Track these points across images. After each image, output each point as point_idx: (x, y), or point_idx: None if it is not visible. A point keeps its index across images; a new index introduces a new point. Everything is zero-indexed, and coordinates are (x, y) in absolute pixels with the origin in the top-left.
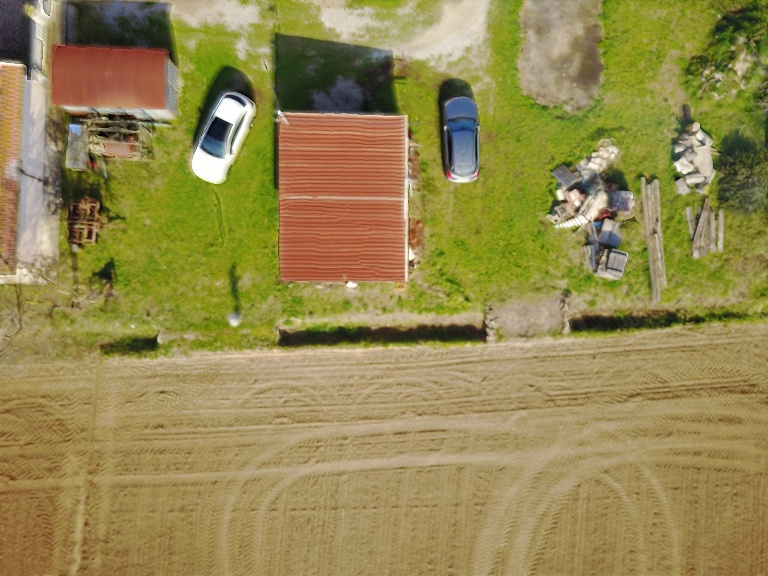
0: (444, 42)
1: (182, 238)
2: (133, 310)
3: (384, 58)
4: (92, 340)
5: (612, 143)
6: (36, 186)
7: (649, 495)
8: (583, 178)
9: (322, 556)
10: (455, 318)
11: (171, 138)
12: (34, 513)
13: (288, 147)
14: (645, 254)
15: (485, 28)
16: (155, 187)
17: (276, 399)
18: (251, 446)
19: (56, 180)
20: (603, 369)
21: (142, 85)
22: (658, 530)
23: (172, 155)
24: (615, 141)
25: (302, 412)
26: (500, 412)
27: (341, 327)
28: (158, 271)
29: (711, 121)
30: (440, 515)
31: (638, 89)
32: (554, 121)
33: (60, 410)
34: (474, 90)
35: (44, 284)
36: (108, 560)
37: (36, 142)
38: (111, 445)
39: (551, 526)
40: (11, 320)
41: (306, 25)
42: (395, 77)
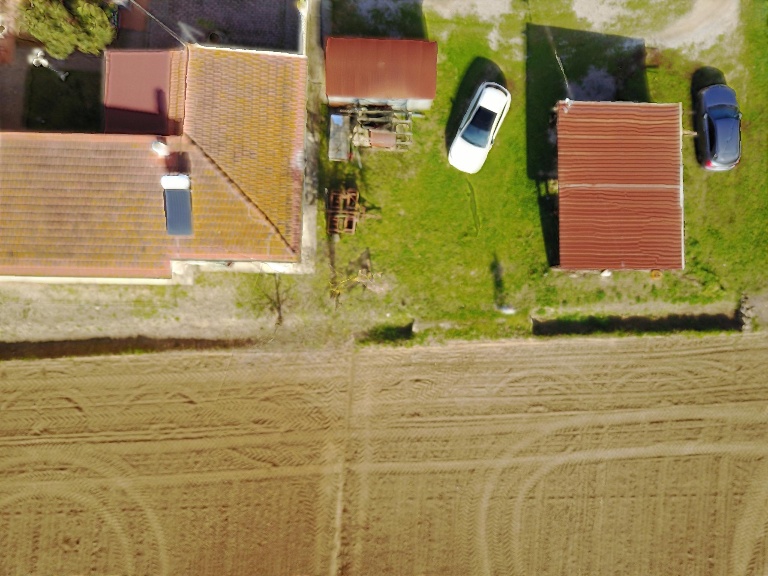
0: (697, 30)
1: (436, 227)
2: (388, 299)
3: (636, 47)
4: (346, 329)
5: None
6: None
7: None
8: None
9: (581, 544)
10: (707, 307)
11: (423, 128)
12: (296, 499)
13: (566, 135)
14: None
15: (738, 15)
16: (409, 177)
17: (531, 387)
18: (507, 434)
19: (313, 170)
20: None
21: (413, 75)
22: None
23: (425, 145)
24: None
25: (557, 400)
26: (757, 401)
27: (591, 316)
28: (412, 260)
29: None
30: (699, 504)
31: None
32: None
33: (317, 398)
34: (727, 78)
35: (303, 273)
36: (369, 546)
37: None
38: (368, 432)
39: None
40: (270, 309)
41: (557, 15)
42: (647, 65)
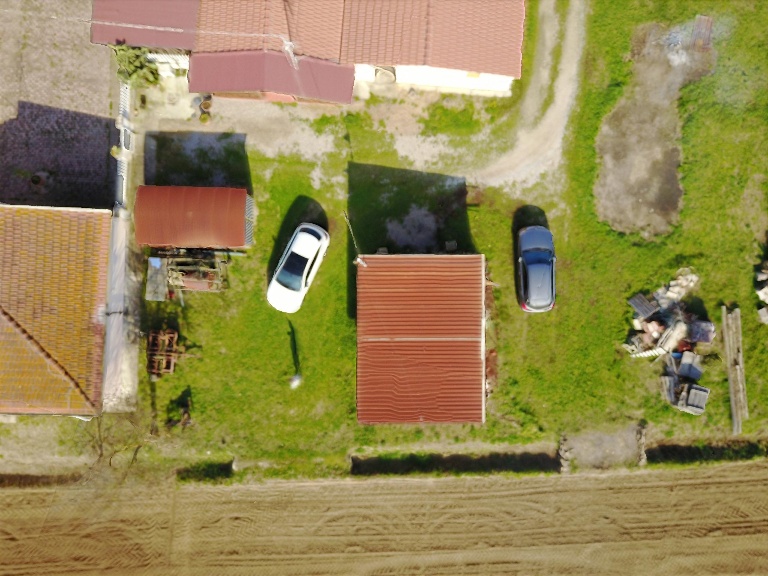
0: (517, 168)
1: (256, 366)
2: (209, 437)
3: (457, 185)
4: (169, 465)
5: (691, 272)
6: (117, 319)
7: None
8: (661, 307)
9: None
10: (528, 446)
11: (245, 266)
12: None
13: (365, 289)
14: (726, 385)
15: (559, 154)
16: (230, 315)
17: (349, 527)
18: (324, 574)
19: (135, 309)
20: (681, 502)
21: (221, 224)
22: None
23: (247, 283)
24: (694, 269)
25: (375, 541)
26: (575, 545)
27: (413, 454)
28: (233, 398)
29: None
30: None
31: (718, 215)
32: (630, 248)
33: (139, 534)
34: (548, 216)
35: (124, 411)
36: None
37: (117, 276)
38: (188, 570)
39: None
40: (92, 446)
41: (378, 153)
42: (468, 204)
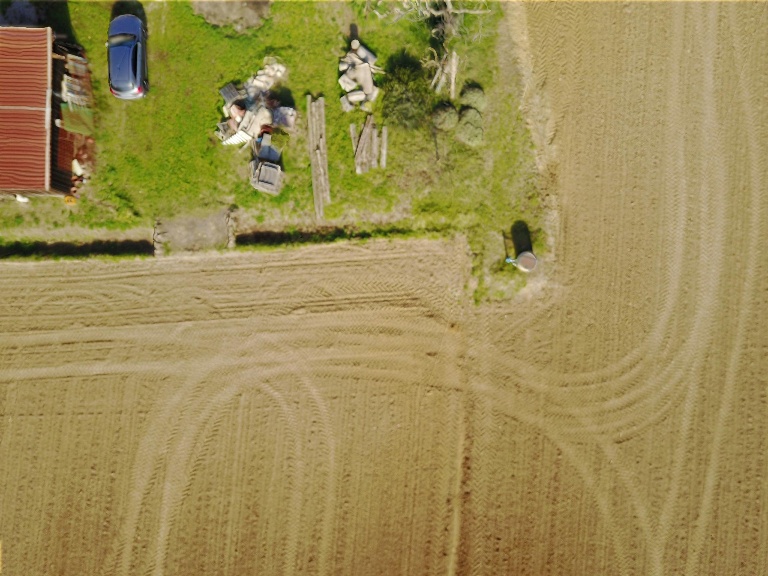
0: None
1: None
2: None
3: None
4: None
5: (277, 61)
6: None
7: (309, 404)
8: (249, 95)
9: None
10: (129, 233)
11: None
12: None
13: None
14: (309, 170)
15: None
16: None
17: None
18: None
19: None
20: (269, 283)
21: None
22: (317, 438)
23: None
24: (281, 59)
25: None
26: (167, 323)
27: (18, 242)
28: None
29: (378, 40)
30: (105, 422)
31: (306, 8)
32: (223, 40)
33: None
34: (146, 9)
35: None
36: None
37: None
38: None
39: (212, 433)
40: None
41: None
42: None
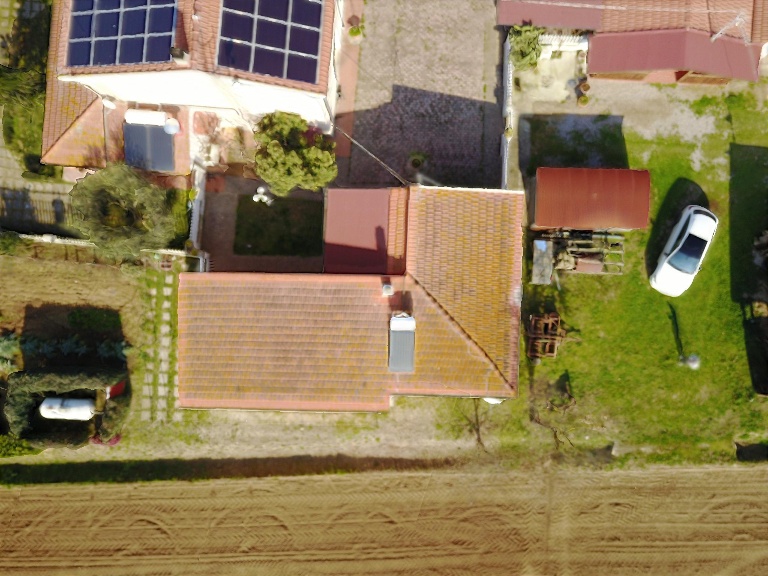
0: None
1: (636, 350)
2: None
3: None
4: (543, 450)
5: None
6: None
7: None
8: None
9: None
10: None
11: None
12: None
13: None
14: None
15: None
16: (608, 299)
17: (736, 515)
18: (712, 562)
19: None
20: None
21: (626, 206)
22: None
23: (624, 267)
24: None
25: (764, 529)
26: None
27: None
28: (612, 383)
29: None
30: None
31: None
32: None
33: (515, 519)
34: None
35: None
36: None
37: None
38: (567, 555)
39: None
40: (469, 430)
41: (762, 134)
42: None
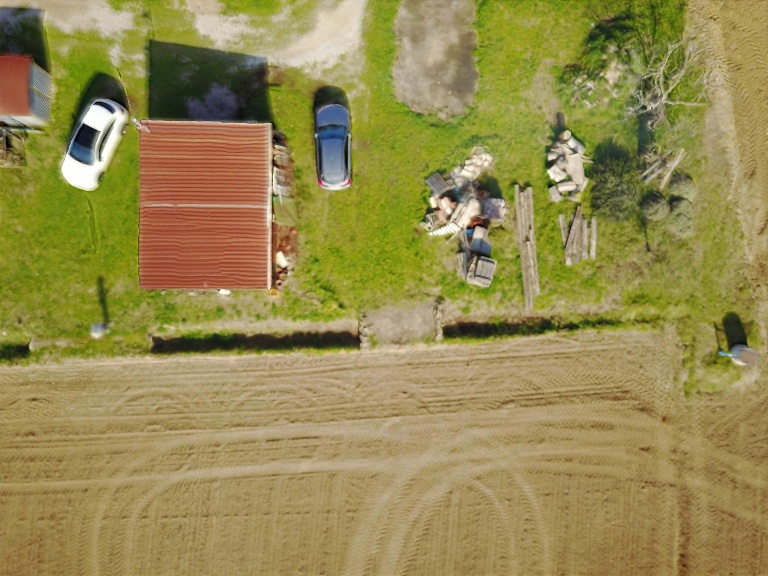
0: (319, 49)
1: (54, 245)
2: (4, 317)
3: (259, 65)
4: None
5: (485, 151)
6: None
7: (521, 501)
8: (456, 186)
9: (193, 563)
10: (330, 325)
11: (44, 145)
12: None
13: (149, 155)
14: (518, 261)
15: (360, 35)
16: (27, 194)
17: (149, 406)
18: (123, 454)
19: None
20: (477, 376)
21: (5, 92)
22: (529, 536)
23: (45, 162)
24: (489, 149)
25: (174, 419)
26: (373, 419)
27: (216, 334)
28: (30, 278)
29: (585, 129)
30: (312, 522)
31: (512, 97)
32: (428, 129)
33: None
34: (349, 97)
35: None
36: None
37: None
38: None
39: (422, 533)
40: None
41: (180, 32)
42: (270, 84)
